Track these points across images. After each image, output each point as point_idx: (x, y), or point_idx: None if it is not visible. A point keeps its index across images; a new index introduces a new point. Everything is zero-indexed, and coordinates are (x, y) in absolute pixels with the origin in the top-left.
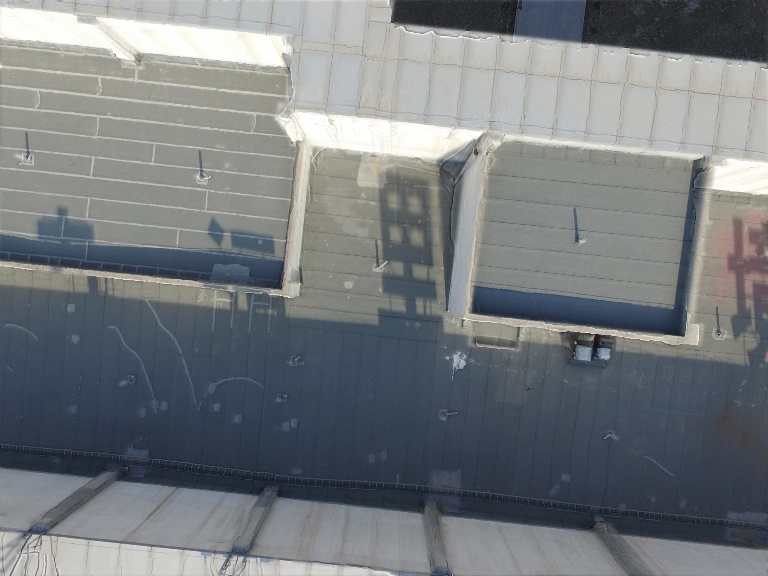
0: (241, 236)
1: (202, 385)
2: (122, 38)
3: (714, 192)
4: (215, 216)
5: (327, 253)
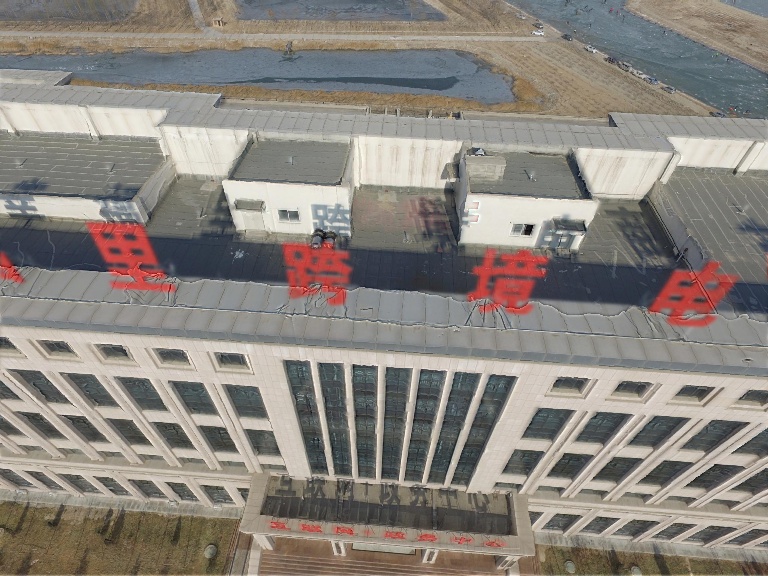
0: (120, 190)
1: (58, 269)
2: (96, 122)
3: (397, 190)
4: (110, 184)
5: (171, 211)
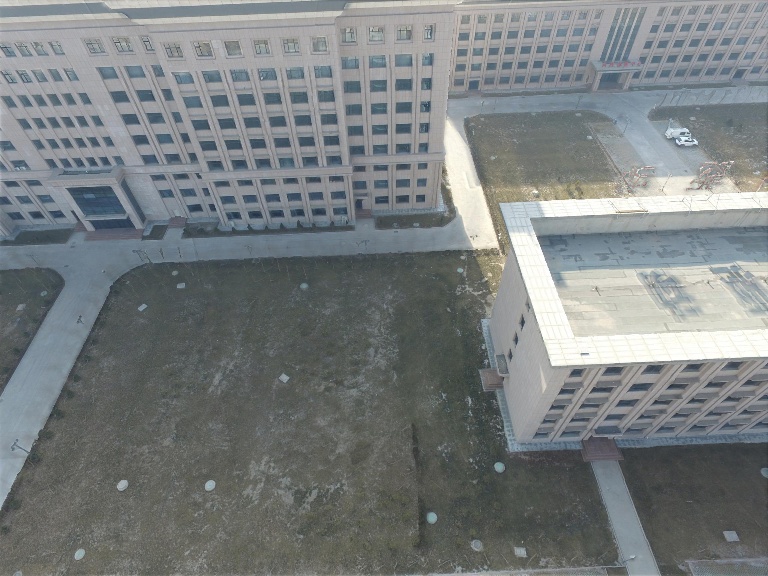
0: None
1: None
2: None
3: None
4: None
5: None
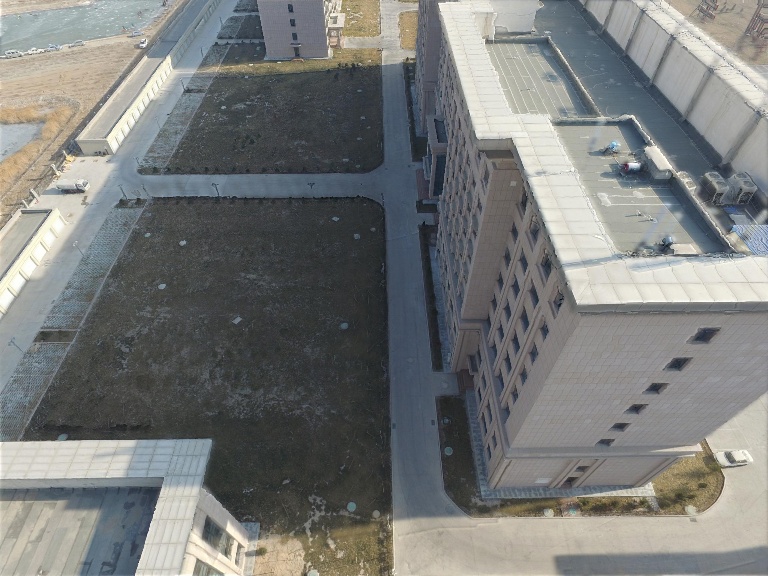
0: None
1: None
2: None
3: None
4: None
5: None
